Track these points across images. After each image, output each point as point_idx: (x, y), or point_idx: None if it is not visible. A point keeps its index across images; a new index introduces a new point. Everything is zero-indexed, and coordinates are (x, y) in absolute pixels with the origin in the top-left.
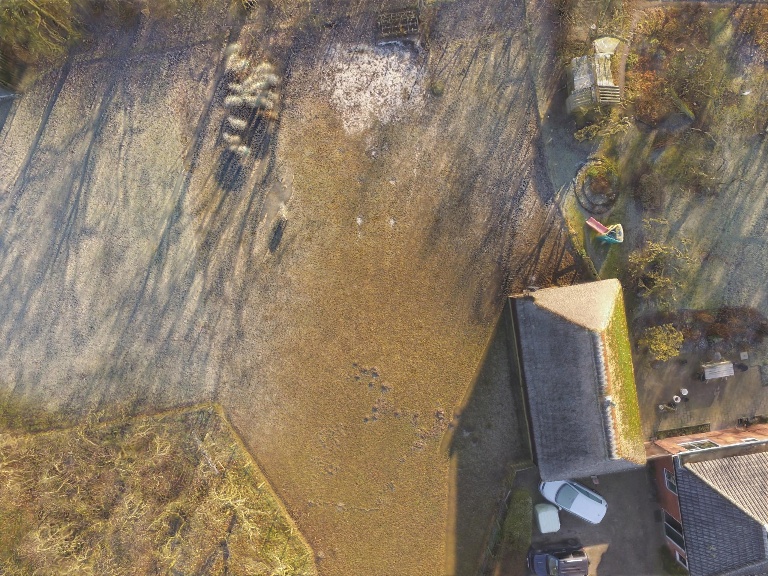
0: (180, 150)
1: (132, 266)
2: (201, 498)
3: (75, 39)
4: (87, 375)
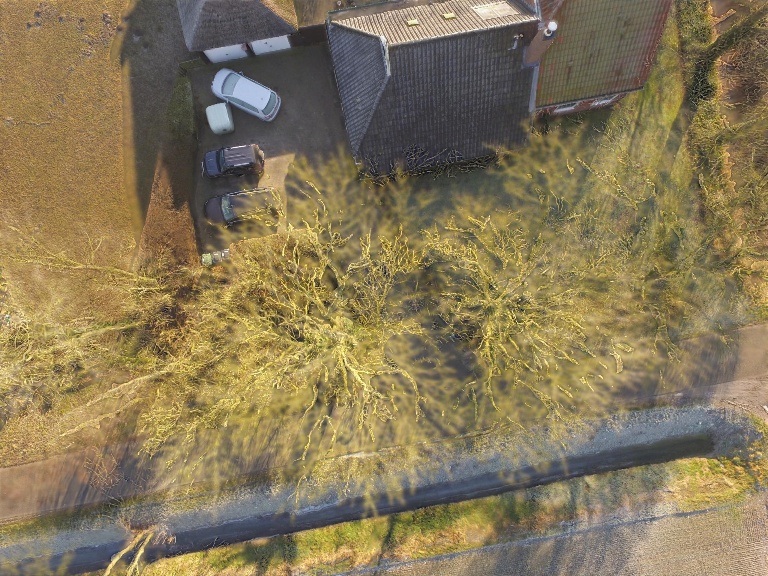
0: None
1: None
2: None
3: None
4: None
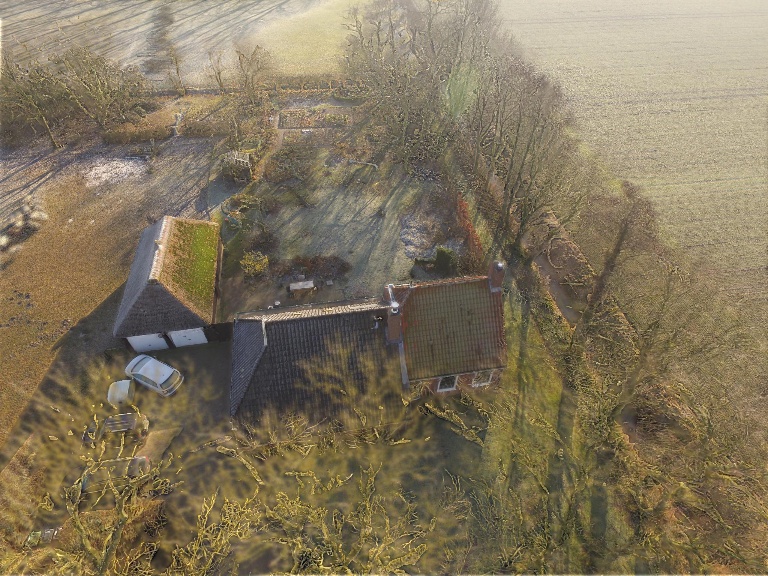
0: None
1: None
2: None
3: None
4: None
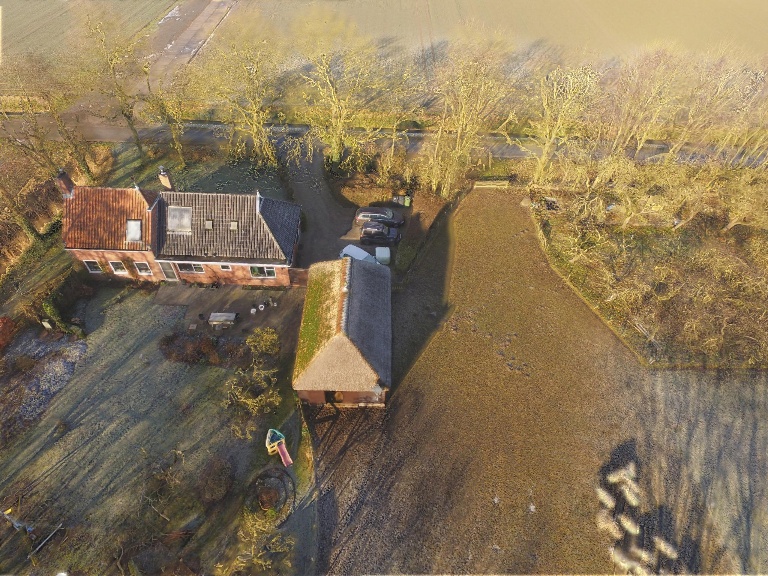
0: None
1: None
2: (642, 307)
3: None
4: None
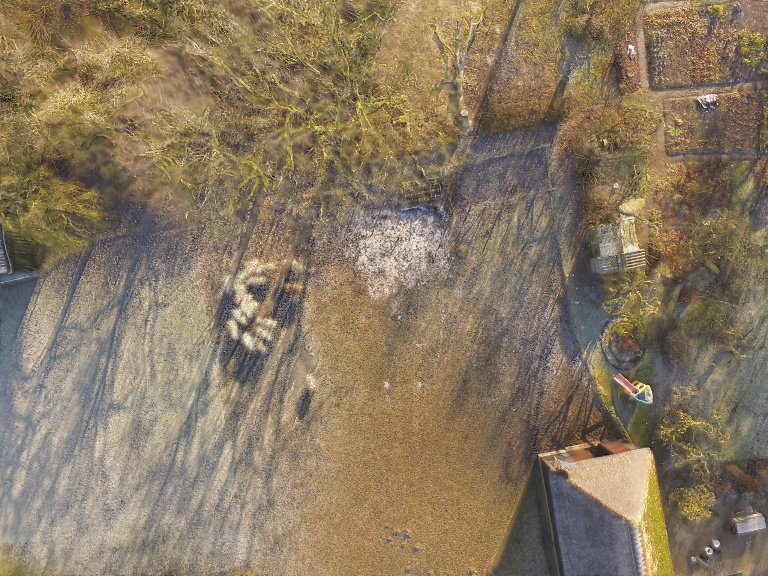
0: (206, 323)
1: (161, 439)
2: None
3: (98, 219)
4: (119, 549)
